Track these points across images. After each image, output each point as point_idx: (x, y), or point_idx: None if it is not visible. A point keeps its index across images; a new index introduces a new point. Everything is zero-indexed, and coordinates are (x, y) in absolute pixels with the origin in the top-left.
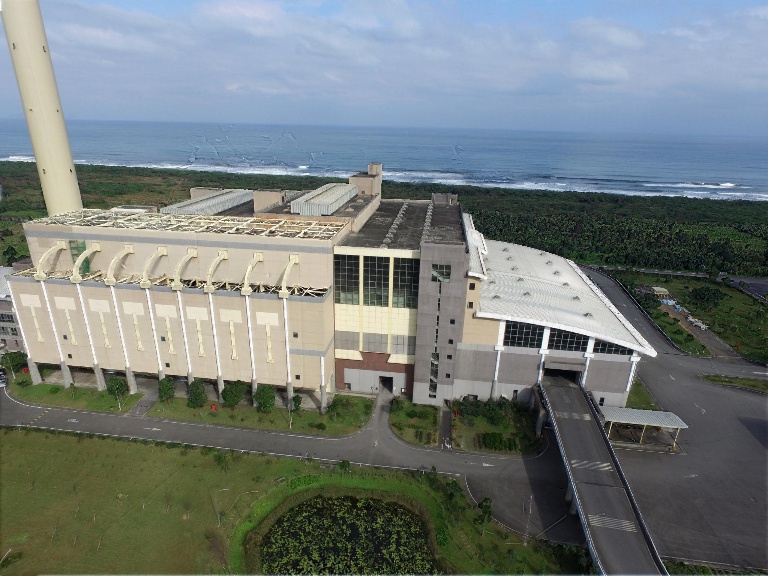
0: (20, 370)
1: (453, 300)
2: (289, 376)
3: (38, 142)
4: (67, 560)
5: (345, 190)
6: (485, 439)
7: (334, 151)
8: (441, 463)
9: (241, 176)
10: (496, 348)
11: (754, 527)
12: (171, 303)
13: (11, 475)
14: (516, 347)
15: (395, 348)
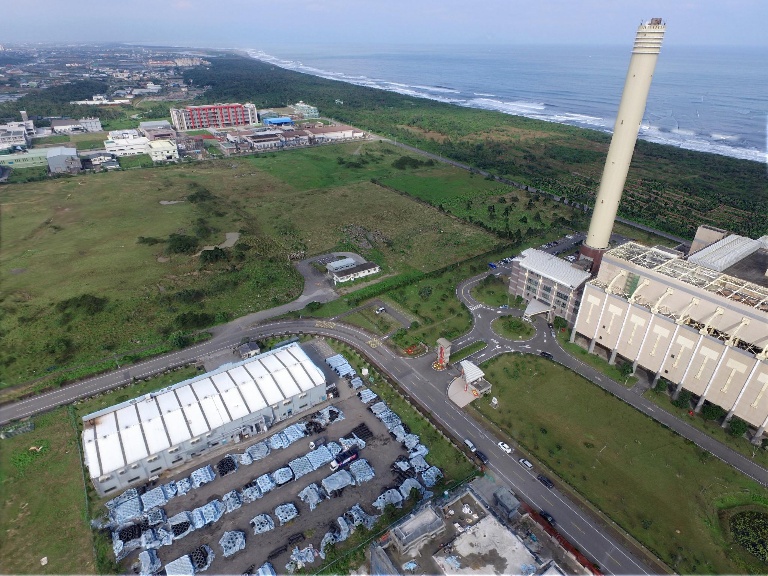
0: (560, 328)
1: None
2: (765, 423)
3: (608, 183)
4: (616, 461)
5: None
6: None
7: None
8: None
9: (696, 155)
10: None
11: None
12: (692, 339)
13: (575, 398)
14: None
15: None
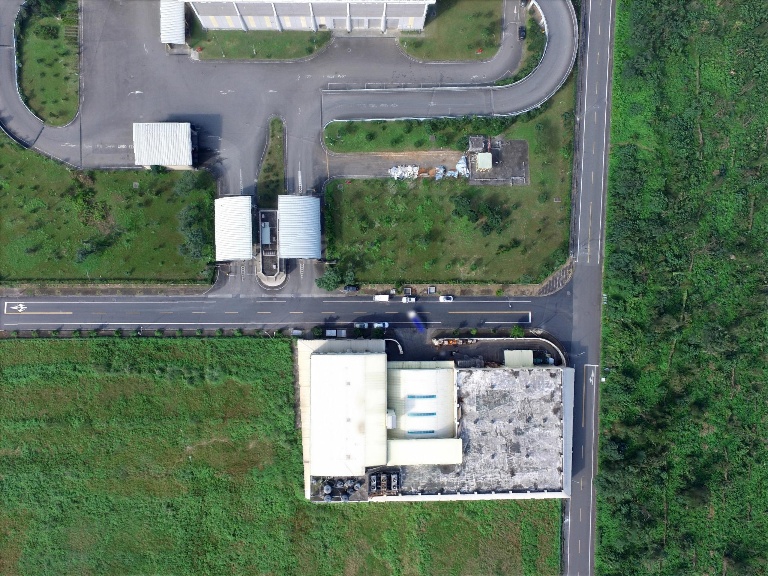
0: None
1: None
2: None
3: None
4: None
5: None
6: None
7: None
8: None
9: None
10: None
11: (109, 65)
12: None
13: None
14: None
15: None
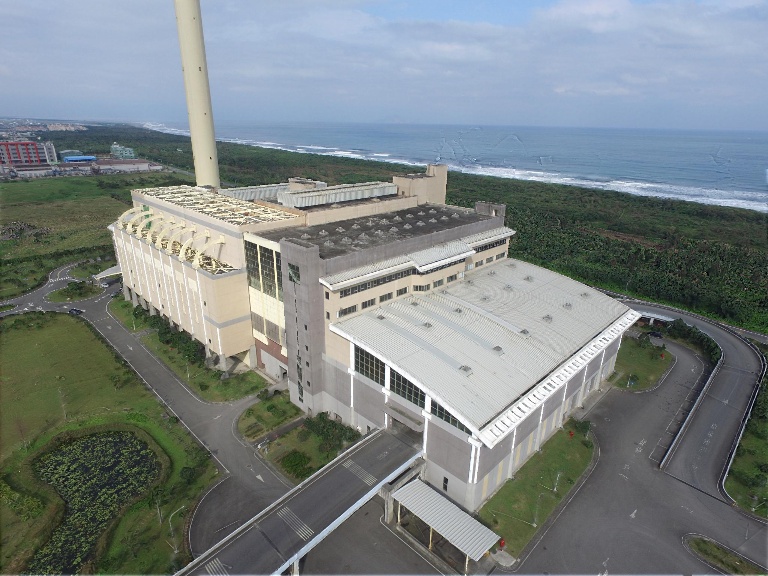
0: None
1: (304, 304)
2: (206, 338)
3: (192, 136)
4: (0, 399)
5: (361, 188)
6: (288, 456)
7: (565, 155)
8: (231, 456)
9: (469, 176)
10: (348, 370)
11: None
12: (159, 259)
13: (48, 345)
14: (364, 376)
15: (284, 341)
